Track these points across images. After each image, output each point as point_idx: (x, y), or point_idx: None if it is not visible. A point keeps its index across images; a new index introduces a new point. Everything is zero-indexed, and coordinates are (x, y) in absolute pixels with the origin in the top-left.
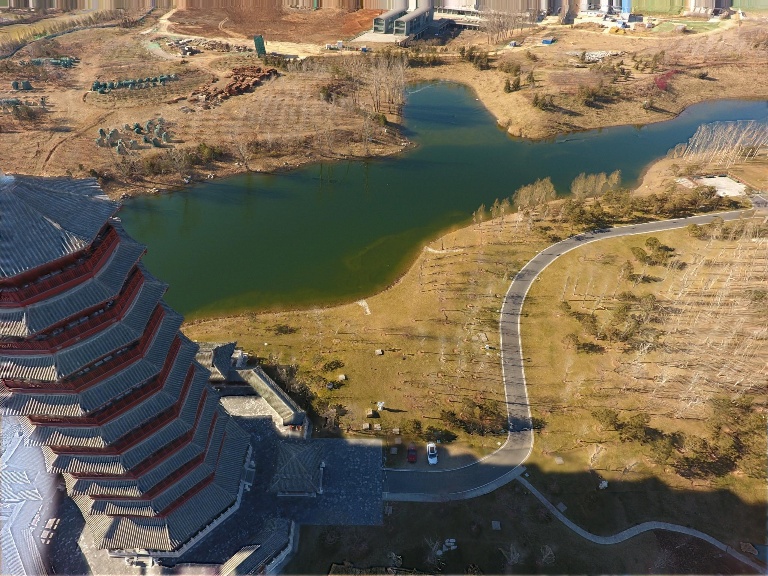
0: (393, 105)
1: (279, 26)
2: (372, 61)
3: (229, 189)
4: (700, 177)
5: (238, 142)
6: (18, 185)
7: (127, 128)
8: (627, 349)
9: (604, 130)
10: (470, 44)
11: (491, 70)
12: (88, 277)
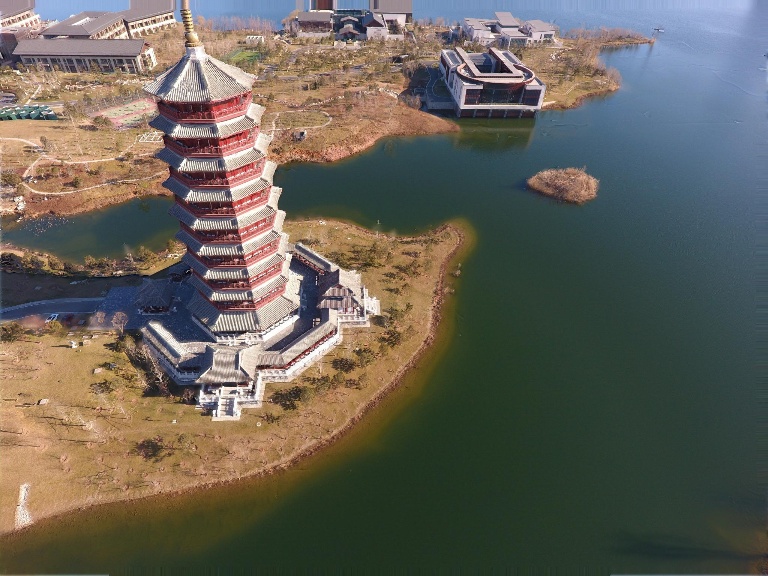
0: None
1: None
2: None
3: None
4: None
5: None
6: None
7: None
8: None
9: None
10: None
11: None
12: None
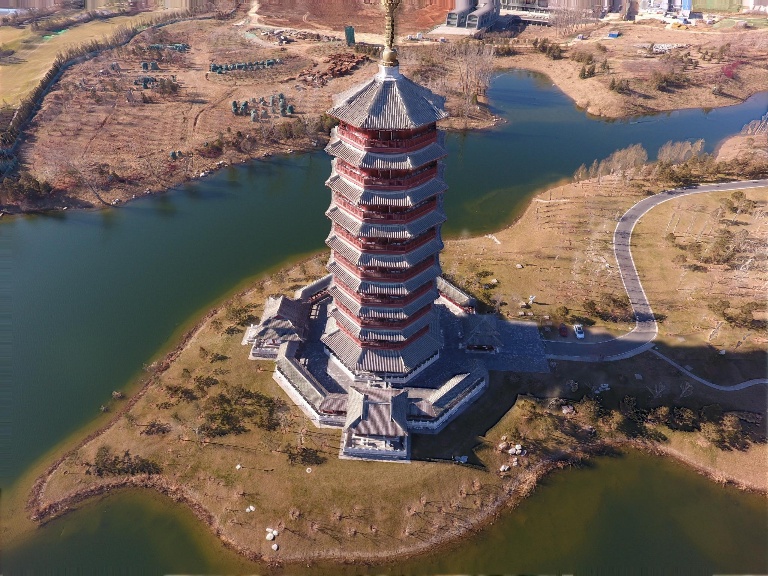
0: (478, 88)
1: (358, 20)
2: (463, 48)
3: None
4: None
5: None
6: (403, 78)
7: (254, 101)
8: (727, 269)
9: (673, 114)
10: (541, 36)
11: (563, 60)
12: (433, 141)
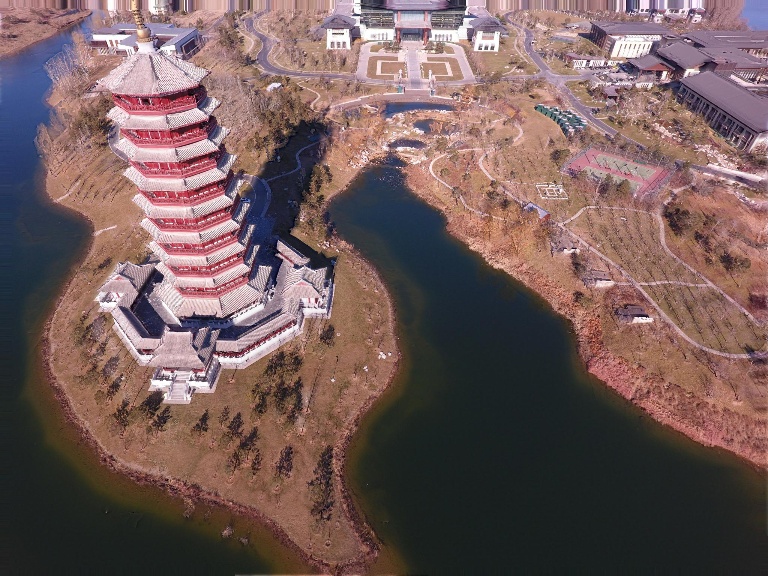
0: None
1: None
2: None
3: None
4: (90, 90)
5: None
6: None
7: None
8: None
9: None
10: None
11: None
12: None
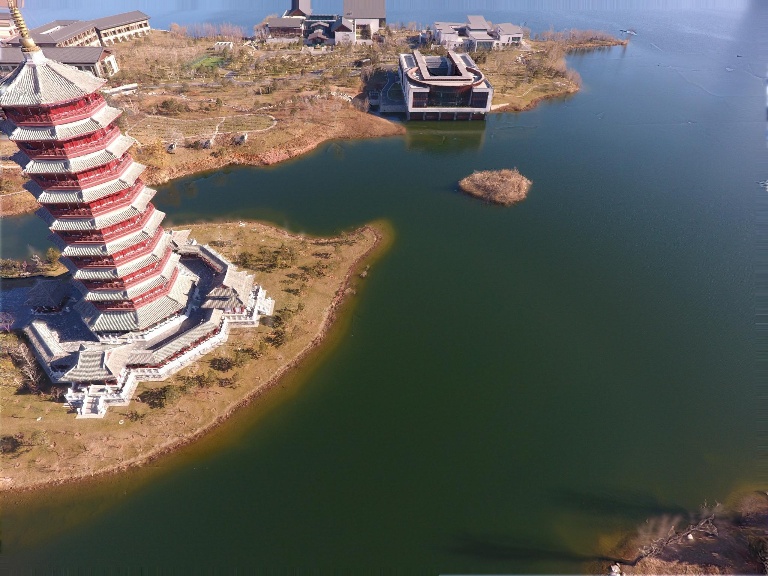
0: None
1: None
2: None
3: None
4: None
5: None
6: None
7: None
8: None
9: None
10: None
11: None
12: None
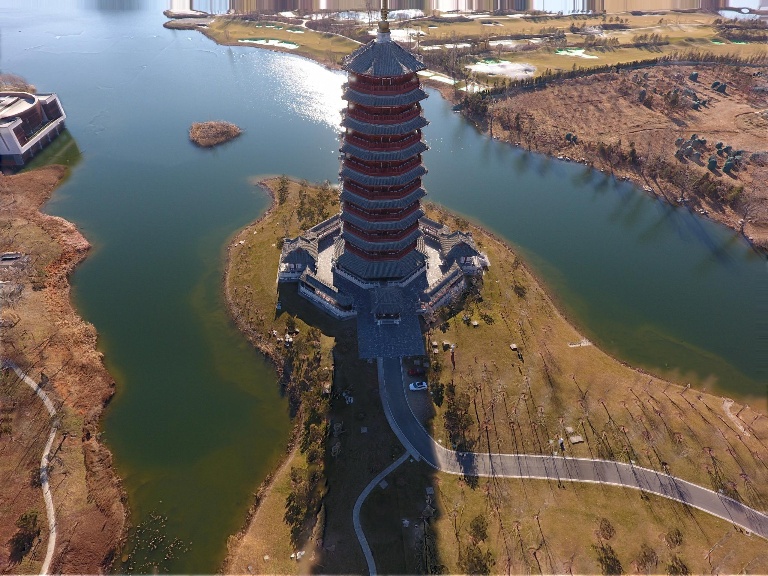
0: None
1: None
2: None
3: (694, 227)
4: None
5: (753, 197)
6: (387, 45)
7: (718, 145)
8: None
9: None
10: None
11: None
12: (370, 93)
